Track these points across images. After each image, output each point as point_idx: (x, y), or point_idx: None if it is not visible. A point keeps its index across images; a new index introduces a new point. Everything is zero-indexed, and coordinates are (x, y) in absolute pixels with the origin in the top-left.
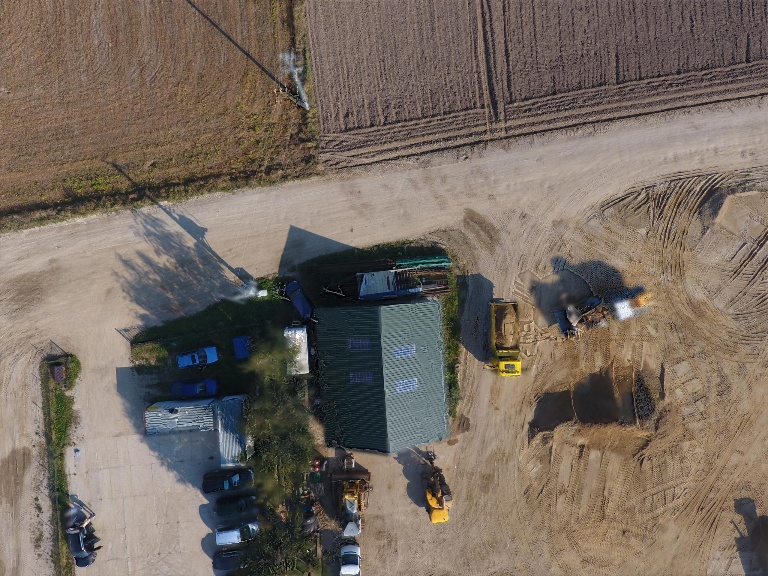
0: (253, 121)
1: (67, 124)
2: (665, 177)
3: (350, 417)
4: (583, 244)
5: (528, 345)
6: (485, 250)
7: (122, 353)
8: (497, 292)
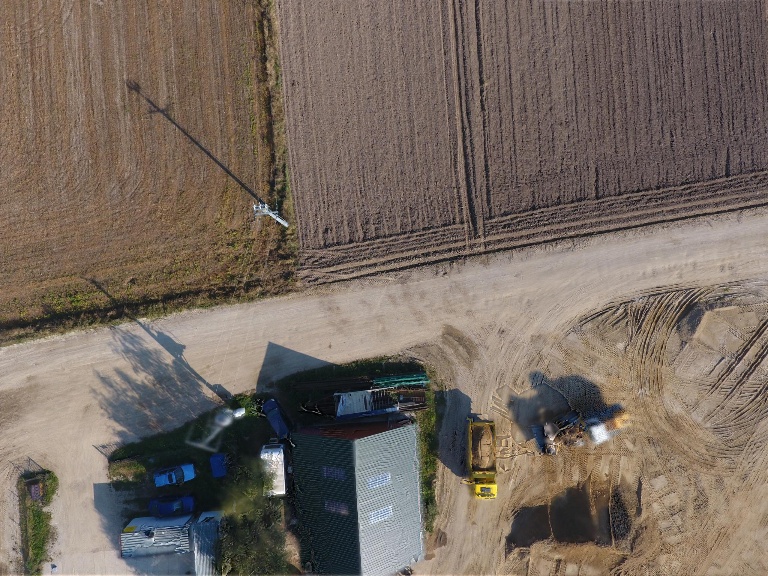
0: (232, 237)
1: (46, 241)
2: (644, 292)
3: (325, 545)
4: (561, 359)
5: (506, 460)
6: (463, 365)
7: (100, 469)
8: (475, 407)
